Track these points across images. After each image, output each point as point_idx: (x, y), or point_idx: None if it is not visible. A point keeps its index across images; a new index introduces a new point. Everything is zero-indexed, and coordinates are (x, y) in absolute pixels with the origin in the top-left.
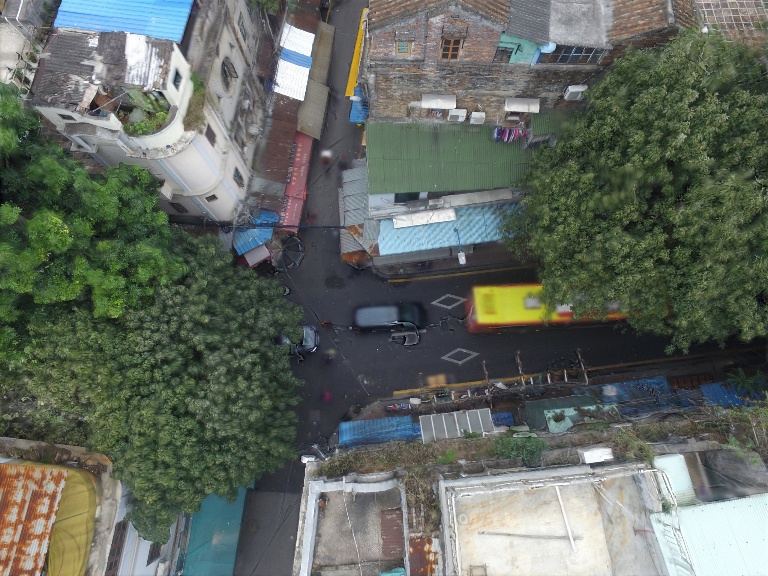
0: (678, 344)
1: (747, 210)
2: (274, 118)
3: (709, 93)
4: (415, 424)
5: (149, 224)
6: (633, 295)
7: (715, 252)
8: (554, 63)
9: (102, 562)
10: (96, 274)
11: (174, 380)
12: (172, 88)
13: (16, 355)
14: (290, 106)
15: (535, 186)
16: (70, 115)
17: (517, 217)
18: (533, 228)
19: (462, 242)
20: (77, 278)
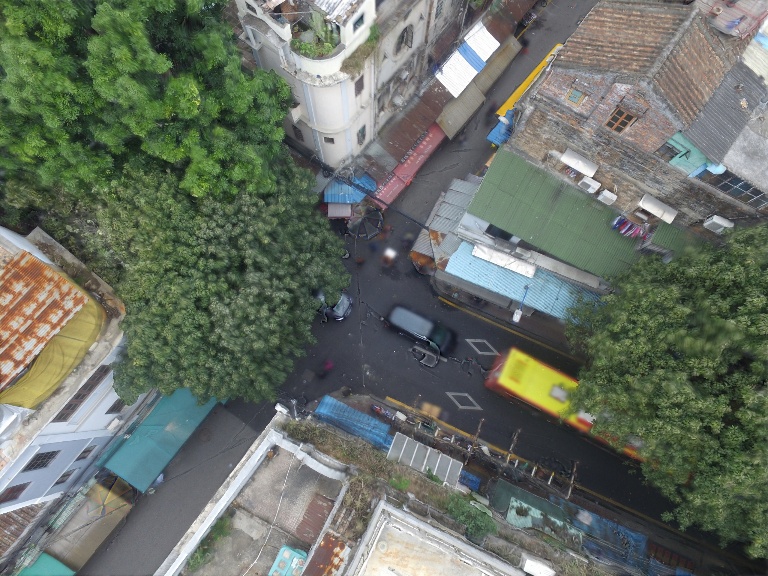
0: (679, 517)
1: None
2: (422, 100)
3: None
4: (389, 436)
5: (266, 134)
6: (662, 445)
7: None
8: (713, 186)
9: (73, 389)
10: (200, 152)
11: (212, 276)
12: (350, 28)
13: (103, 182)
14: (442, 96)
15: (626, 290)
16: (255, 8)
17: (591, 308)
18: (600, 327)
19: (526, 301)
20: (184, 146)
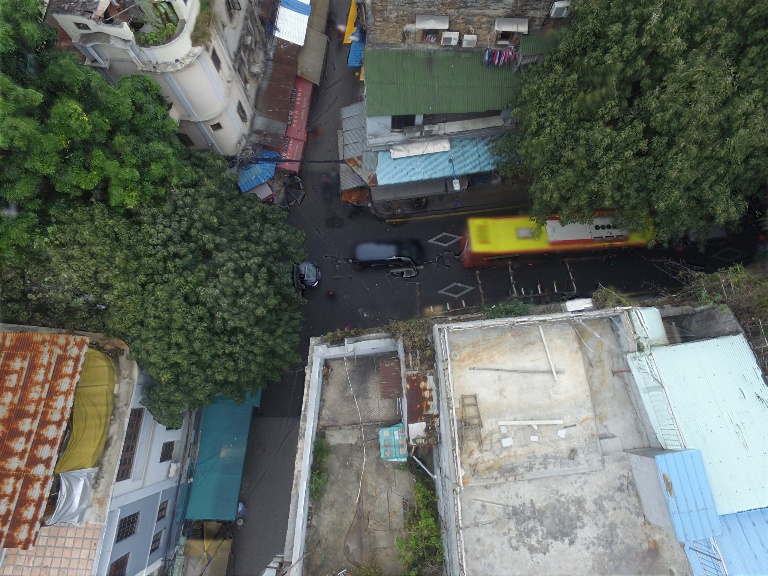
0: (658, 238)
1: (718, 94)
2: (275, 61)
3: (686, 5)
4: None
5: (160, 130)
6: (615, 190)
7: (689, 135)
8: None
9: (121, 433)
10: (113, 164)
11: (185, 272)
12: (181, 1)
13: None
14: (290, 50)
15: (524, 96)
16: (85, 23)
17: (508, 139)
18: None
19: (457, 172)
20: (95, 169)
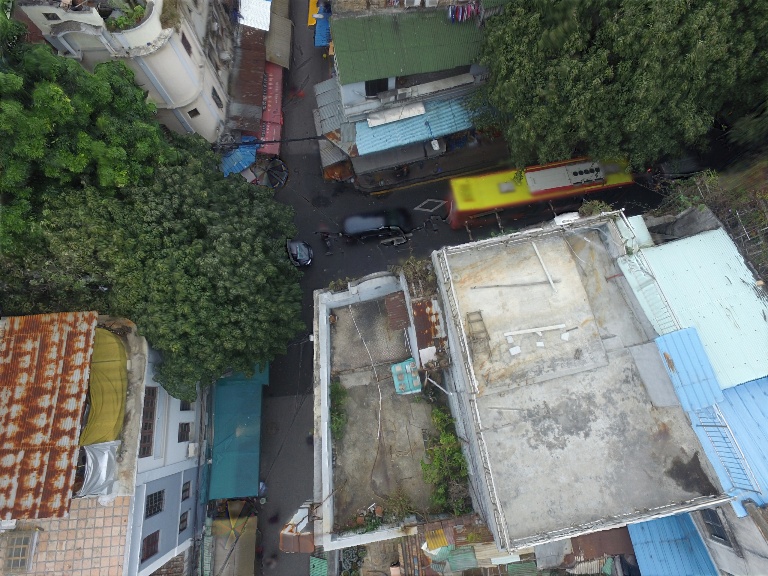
0: (634, 163)
1: (673, 12)
2: (243, 48)
3: None
4: None
5: (141, 112)
6: (588, 120)
7: (650, 54)
8: None
9: (138, 407)
10: (99, 145)
11: (183, 246)
12: None
13: None
14: (257, 36)
15: (490, 44)
16: (55, 13)
17: (480, 93)
18: None
19: (434, 134)
20: (82, 151)
